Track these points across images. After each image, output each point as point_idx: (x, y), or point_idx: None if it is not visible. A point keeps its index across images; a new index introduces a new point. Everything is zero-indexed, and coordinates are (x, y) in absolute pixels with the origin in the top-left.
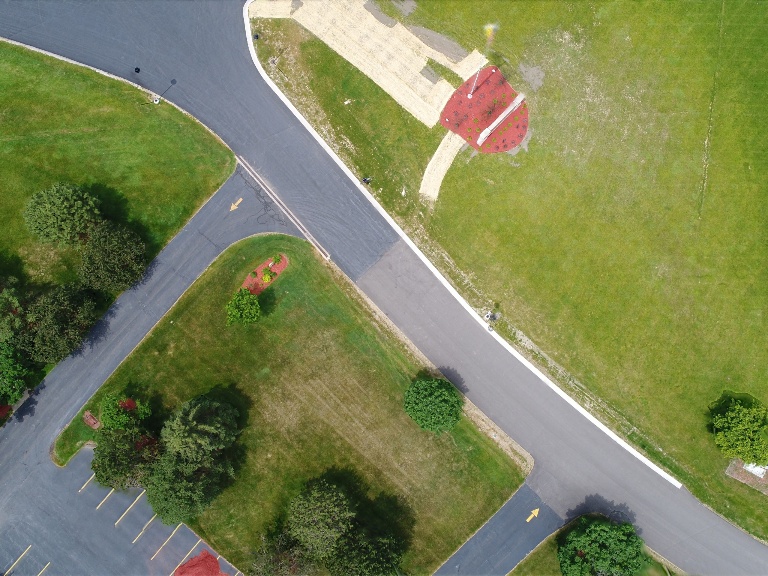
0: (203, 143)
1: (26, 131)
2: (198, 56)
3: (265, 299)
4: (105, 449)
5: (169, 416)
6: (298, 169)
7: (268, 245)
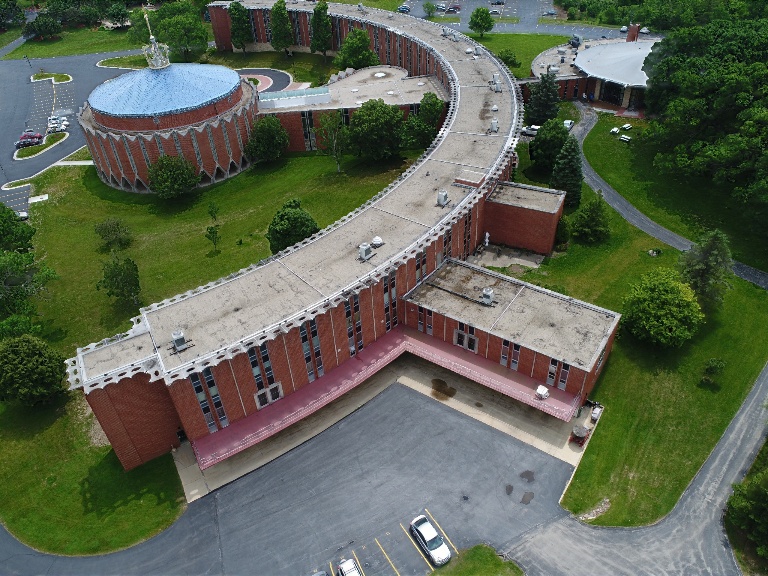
0: None
1: None
2: None
3: None
4: (13, 6)
5: None
6: None
7: None
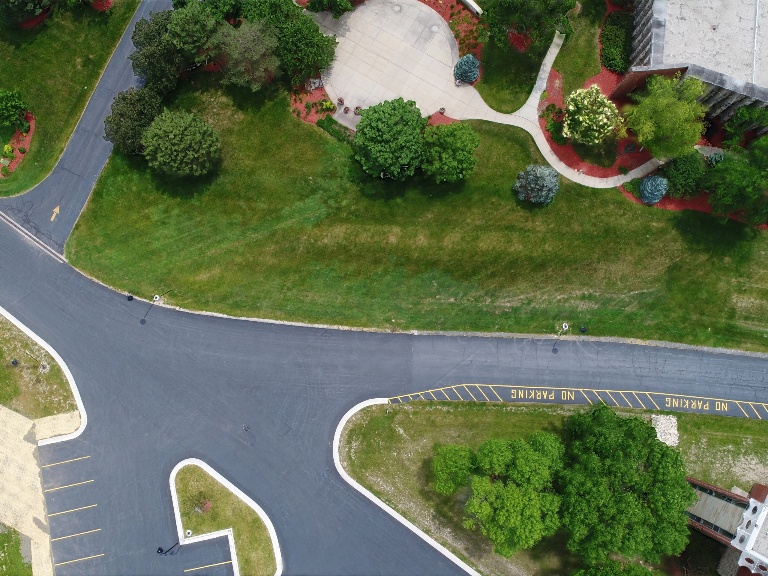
0: (101, 266)
1: (275, 234)
2: (124, 356)
3: (8, 131)
4: None
5: (65, 6)
6: (2, 263)
7: (18, 183)
